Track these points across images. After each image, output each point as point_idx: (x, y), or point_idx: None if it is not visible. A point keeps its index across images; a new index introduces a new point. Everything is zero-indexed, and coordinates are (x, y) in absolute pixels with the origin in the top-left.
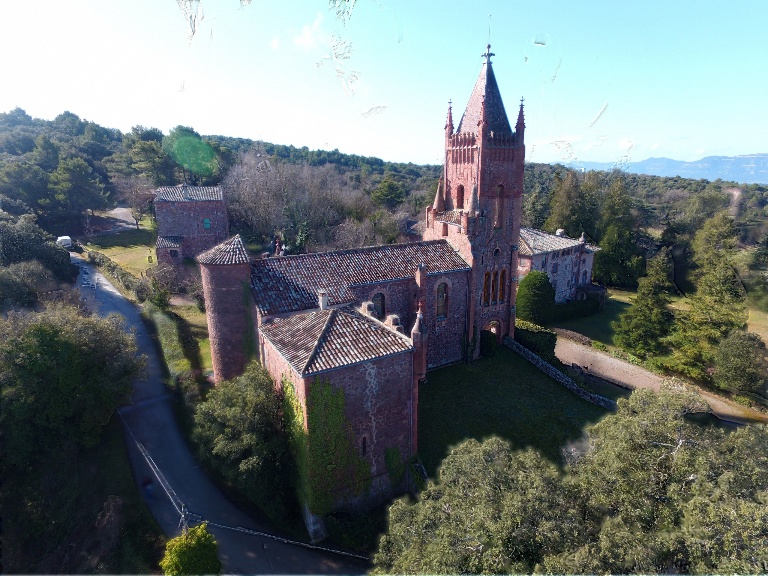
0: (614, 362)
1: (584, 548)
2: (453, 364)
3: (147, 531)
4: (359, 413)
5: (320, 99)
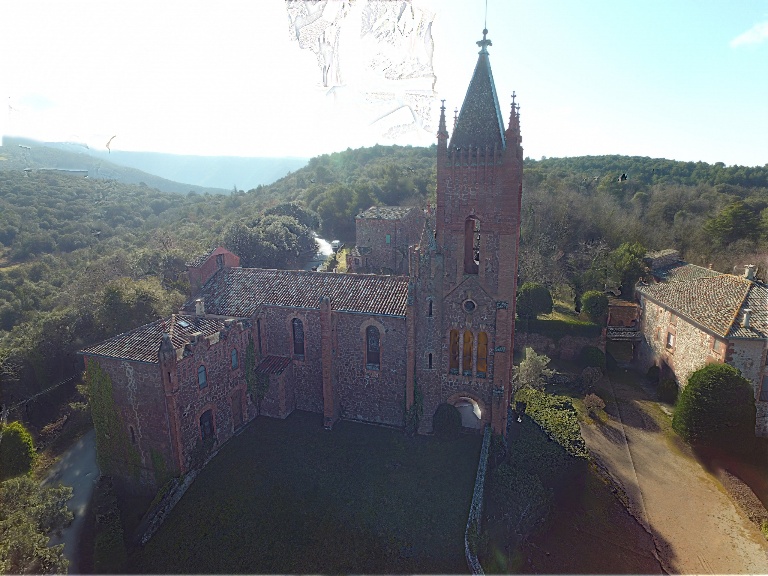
0: (761, 575)
1: None
2: (388, 427)
3: (84, 429)
4: (125, 403)
5: None
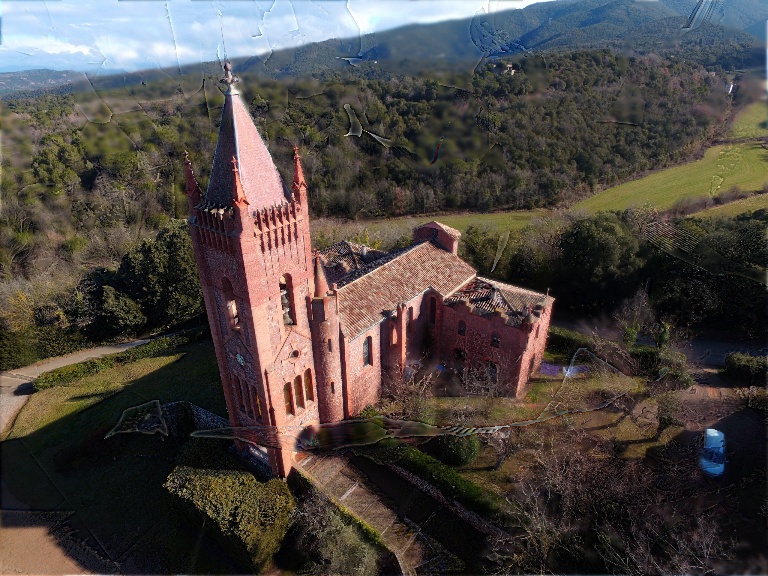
0: None
1: None
2: None
3: None
4: None
5: None
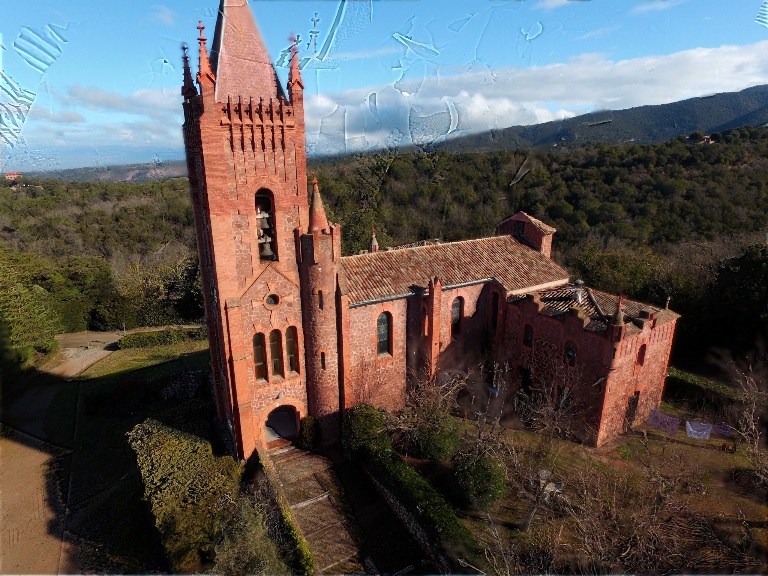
0: None
1: None
2: None
3: None
4: None
5: (490, 64)
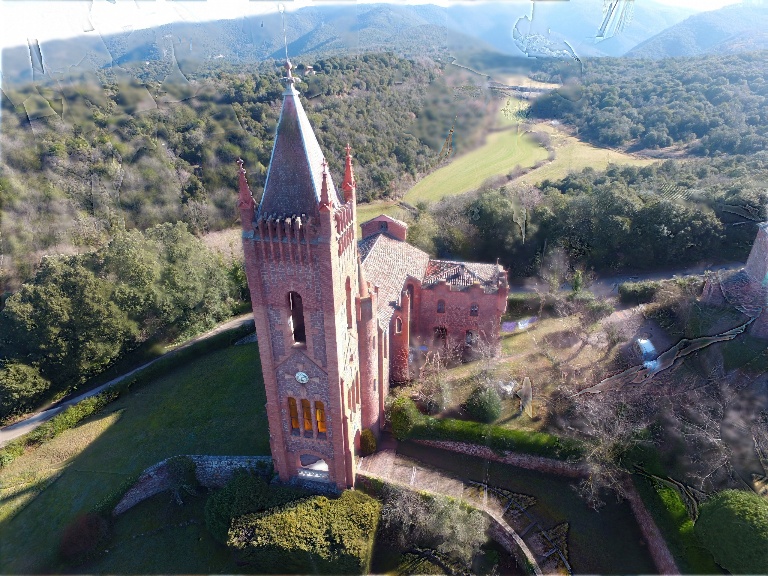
0: None
1: None
2: None
3: None
4: None
5: None
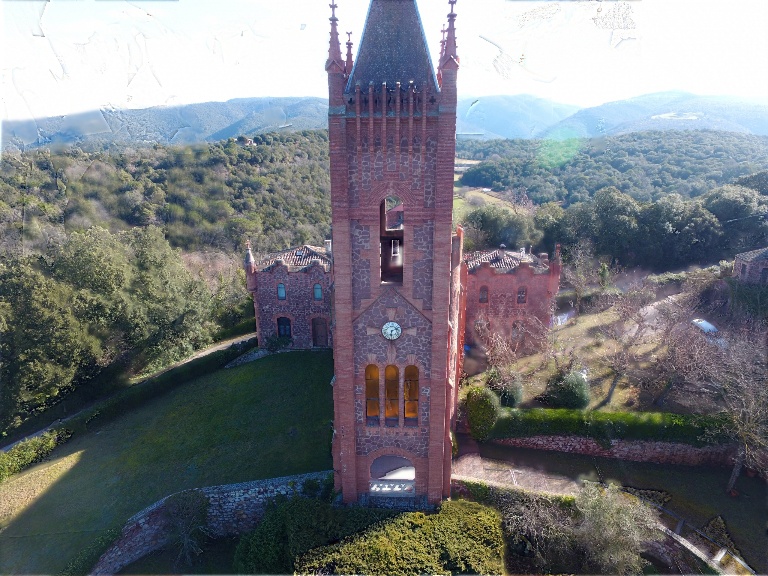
0: None
1: (123, 233)
2: None
3: None
4: None
5: None
